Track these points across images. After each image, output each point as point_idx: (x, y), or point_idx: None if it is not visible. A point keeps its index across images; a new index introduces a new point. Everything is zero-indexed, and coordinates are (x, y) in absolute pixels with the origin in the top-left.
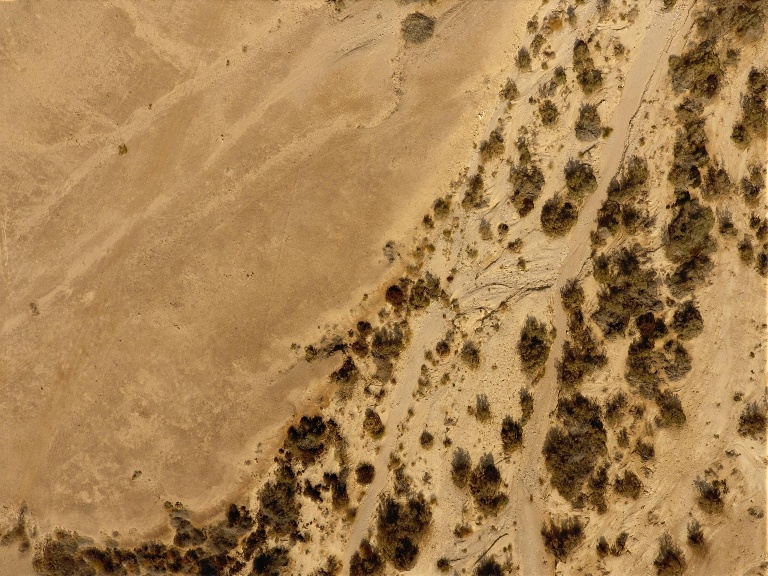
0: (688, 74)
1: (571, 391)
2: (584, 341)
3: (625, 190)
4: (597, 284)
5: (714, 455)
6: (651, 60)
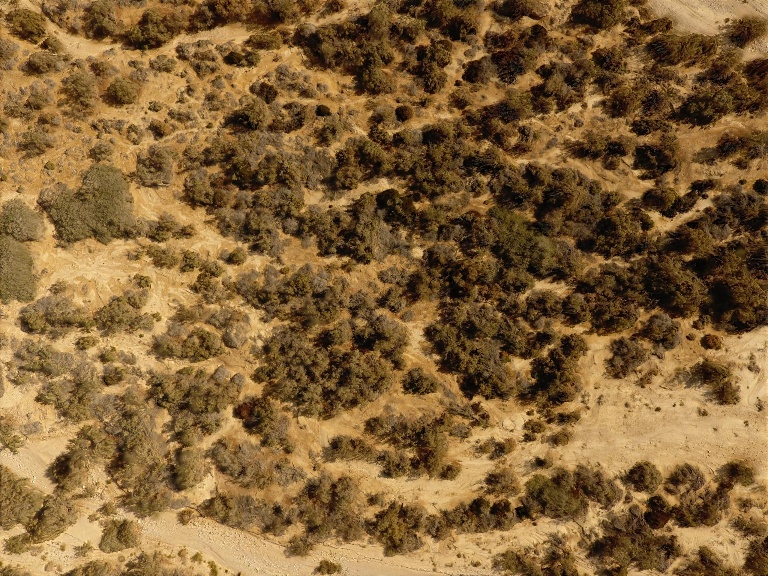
0: (407, 548)
1: (743, 575)
2: (690, 575)
3: (531, 575)
4: (628, 574)
5: (765, 421)
6: (392, 572)
